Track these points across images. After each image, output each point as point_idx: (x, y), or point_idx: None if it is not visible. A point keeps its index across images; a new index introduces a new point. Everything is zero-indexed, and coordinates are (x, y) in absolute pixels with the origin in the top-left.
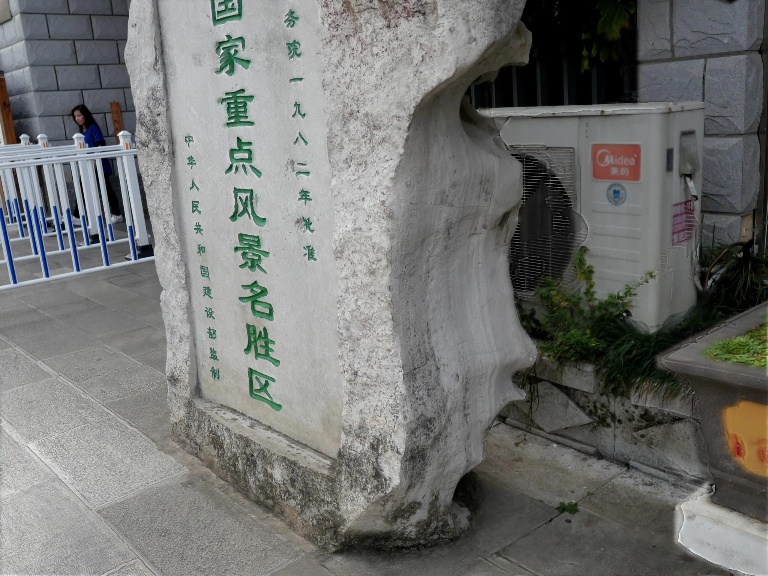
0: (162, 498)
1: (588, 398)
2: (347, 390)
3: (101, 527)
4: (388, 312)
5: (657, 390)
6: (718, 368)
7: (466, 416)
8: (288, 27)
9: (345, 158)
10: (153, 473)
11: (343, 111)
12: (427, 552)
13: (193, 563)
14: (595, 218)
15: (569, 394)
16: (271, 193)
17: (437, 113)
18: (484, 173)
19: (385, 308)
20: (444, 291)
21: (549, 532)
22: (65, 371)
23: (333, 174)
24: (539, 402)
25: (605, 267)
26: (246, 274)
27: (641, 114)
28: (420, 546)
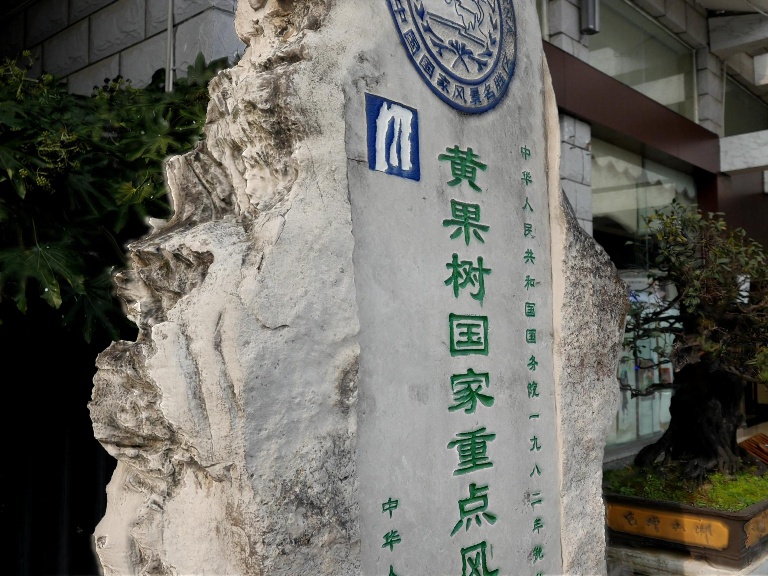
0: None
1: None
2: None
3: None
4: None
5: None
6: (748, 513)
7: None
8: (531, 370)
9: (571, 478)
10: None
11: None
12: None
13: None
14: None
15: None
16: (509, 536)
17: None
18: None
19: None
20: None
21: None
22: None
23: (563, 495)
24: None
25: None
26: None
27: None
28: None
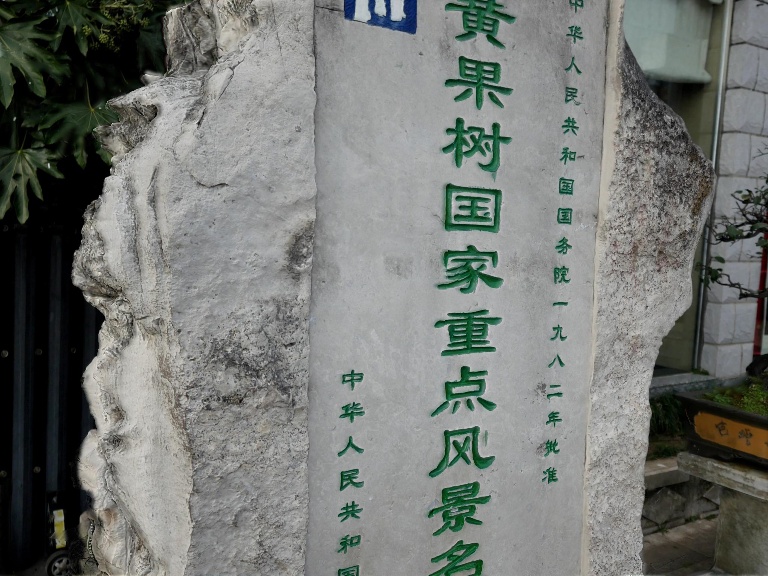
0: None
1: None
2: None
3: None
4: (640, 495)
5: None
6: None
7: None
8: (561, 253)
9: (607, 374)
10: None
11: None
12: None
13: None
14: None
15: None
16: (512, 424)
17: None
18: None
19: (637, 493)
20: None
21: None
22: None
23: (593, 390)
24: None
25: None
26: (445, 539)
27: None
28: None
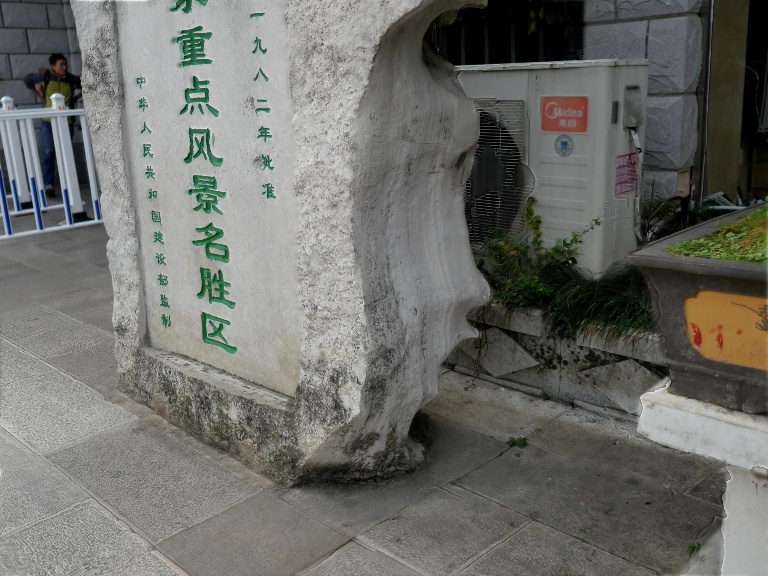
0: (113, 443)
1: (535, 341)
2: (306, 325)
3: (51, 471)
4: (350, 244)
5: (600, 332)
6: (679, 261)
7: (423, 350)
8: None
9: (308, 92)
10: (102, 421)
11: (307, 44)
12: (384, 483)
13: (149, 500)
14: (543, 169)
15: (516, 339)
16: (229, 132)
17: (401, 47)
18: (444, 110)
19: (347, 240)
20: (403, 227)
21: (499, 465)
22: (1, 329)
23: (295, 109)
24: (487, 347)
25: (552, 217)
26: (201, 216)
27: (588, 67)
28: (377, 478)
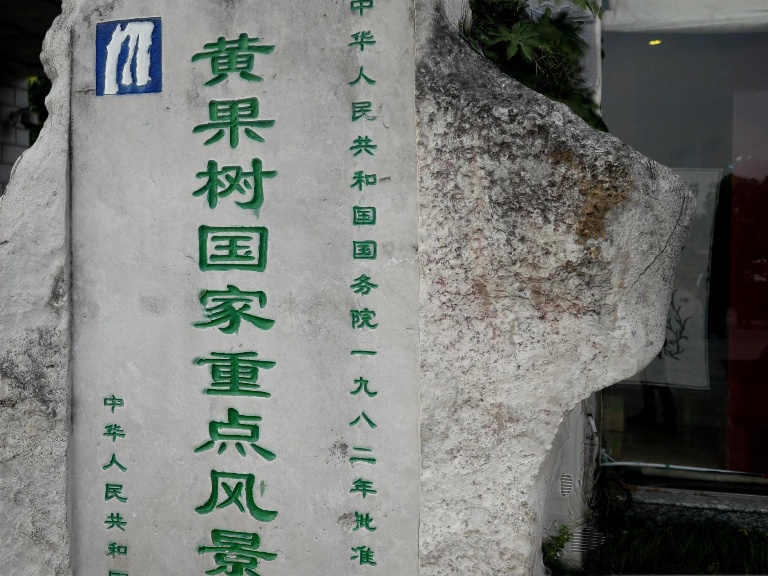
0: None
1: None
2: None
3: None
4: None
5: None
6: None
7: None
8: (357, 293)
9: (450, 448)
10: None
11: (456, 397)
12: None
13: None
14: None
15: None
16: (296, 481)
17: None
18: None
19: None
20: None
21: None
22: None
23: (425, 465)
24: None
25: None
26: None
27: None
28: None
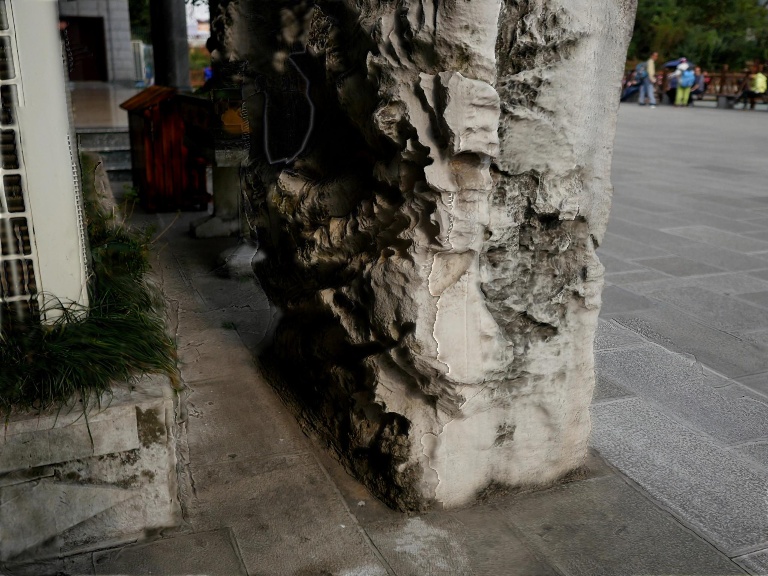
0: None
1: None
2: None
3: (617, 381)
4: None
5: None
6: None
7: None
8: None
9: None
10: None
11: None
12: None
13: None
14: None
15: None
16: None
17: None
18: (292, 42)
19: None
20: None
21: None
22: None
23: None
24: None
25: None
26: None
27: None
28: None
